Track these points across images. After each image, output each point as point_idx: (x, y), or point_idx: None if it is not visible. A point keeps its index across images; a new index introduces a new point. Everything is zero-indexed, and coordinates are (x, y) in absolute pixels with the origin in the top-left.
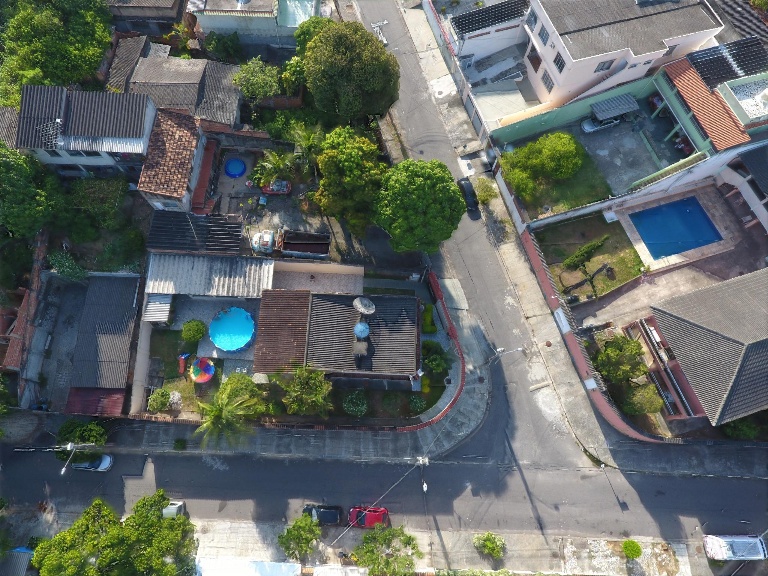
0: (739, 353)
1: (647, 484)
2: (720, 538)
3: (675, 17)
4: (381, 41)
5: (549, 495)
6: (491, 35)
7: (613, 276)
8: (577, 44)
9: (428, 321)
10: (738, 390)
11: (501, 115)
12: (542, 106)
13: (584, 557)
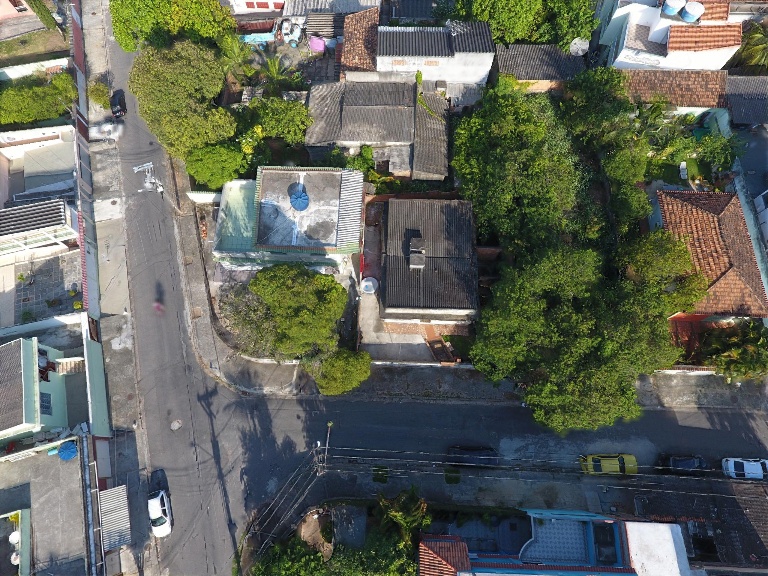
0: None
1: None
2: None
3: None
4: None
5: None
6: None
7: None
8: None
9: None
10: None
11: (55, 149)
12: (8, 149)
13: None
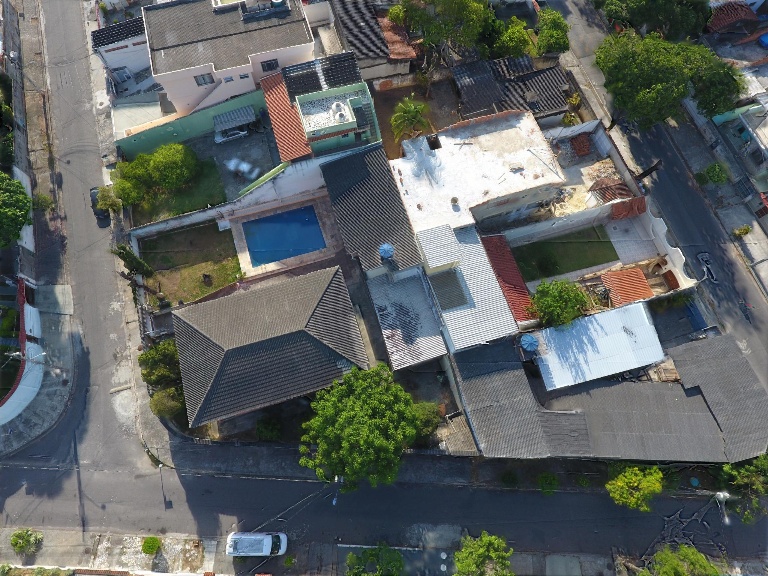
0: (220, 358)
1: (198, 483)
2: (231, 535)
3: (275, 33)
4: (9, 55)
5: (99, 493)
6: (131, 48)
7: (210, 283)
8: (167, 59)
9: (4, 326)
10: (217, 394)
11: (133, 126)
12: (170, 118)
13: (116, 553)
